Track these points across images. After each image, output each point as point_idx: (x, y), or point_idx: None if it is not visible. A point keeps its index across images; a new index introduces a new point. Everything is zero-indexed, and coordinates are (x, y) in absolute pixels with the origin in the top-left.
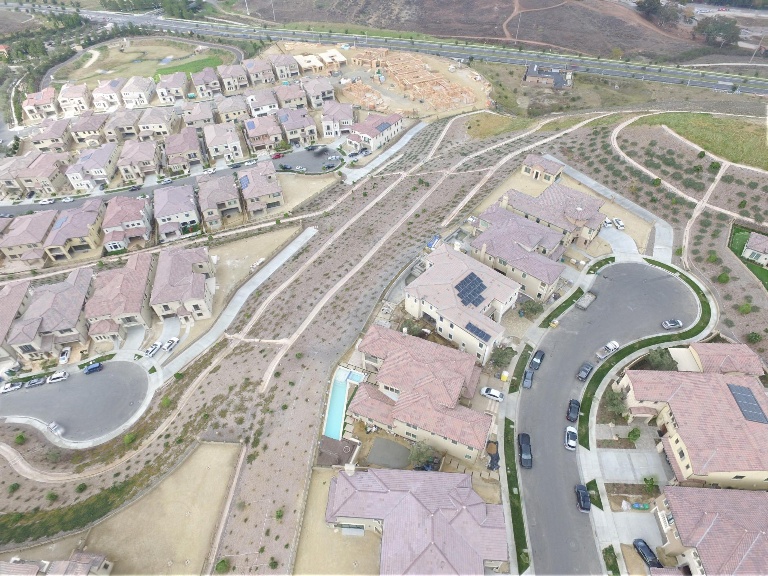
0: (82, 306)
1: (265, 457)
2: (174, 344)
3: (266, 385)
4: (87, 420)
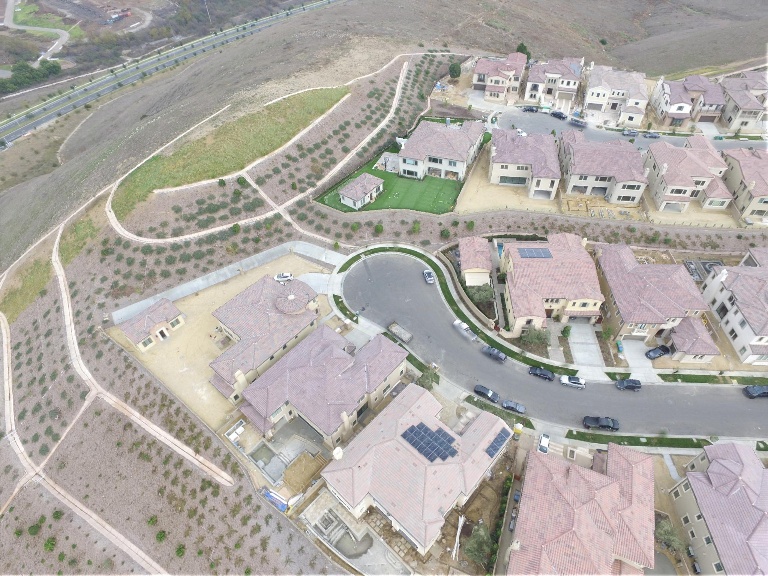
0: None
1: None
2: None
3: None
4: None
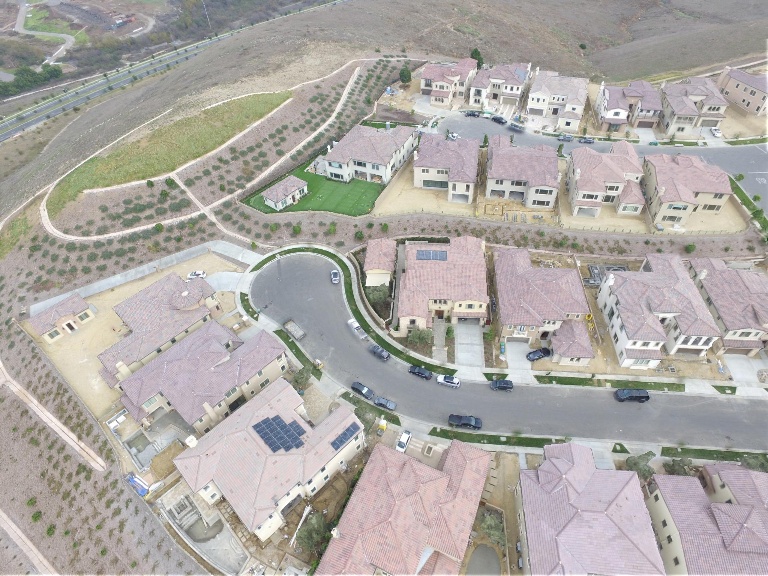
0: None
1: None
2: None
3: None
4: None
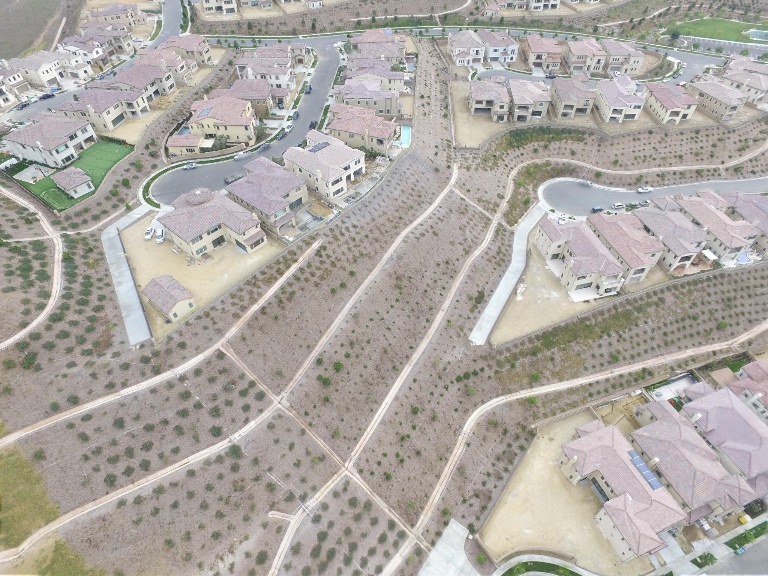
0: (644, 223)
1: None
2: None
3: None
4: (571, 188)
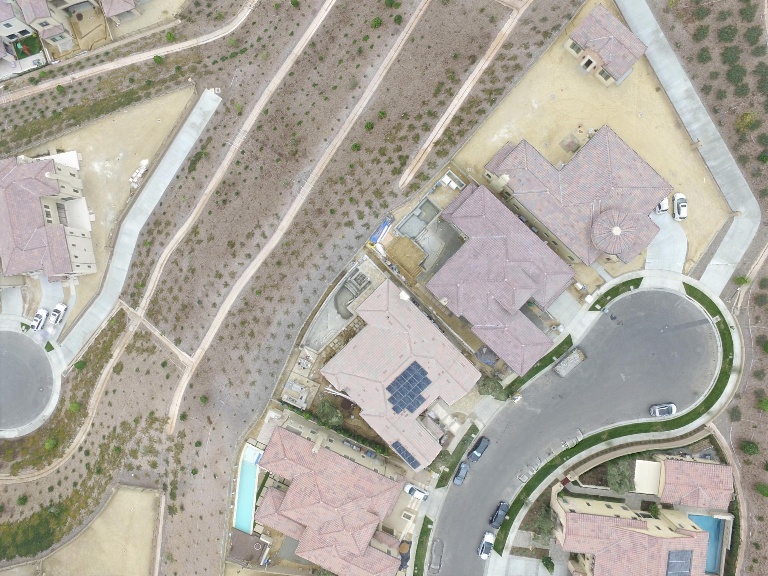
0: None
1: (183, 519)
2: (62, 314)
3: (174, 424)
4: (1, 406)
